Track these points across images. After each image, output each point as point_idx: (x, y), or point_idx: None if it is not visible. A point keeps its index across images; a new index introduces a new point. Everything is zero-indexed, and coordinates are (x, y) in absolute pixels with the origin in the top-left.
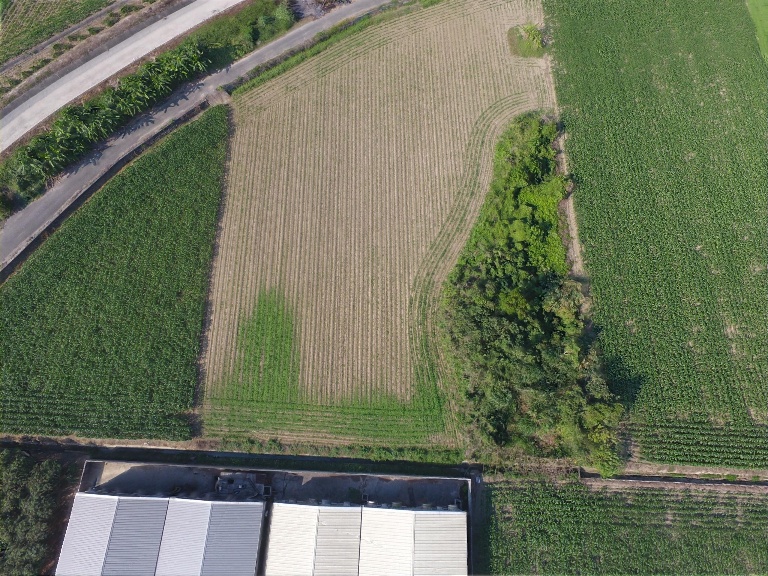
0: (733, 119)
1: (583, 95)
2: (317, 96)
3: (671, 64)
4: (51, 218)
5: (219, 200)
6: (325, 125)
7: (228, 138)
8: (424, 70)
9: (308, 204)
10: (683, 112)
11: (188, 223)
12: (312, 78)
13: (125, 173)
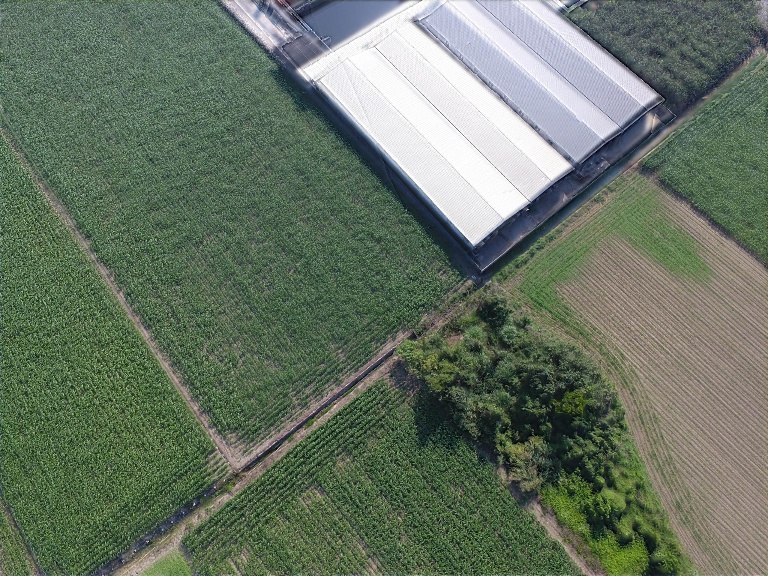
0: None
1: None
2: None
3: None
4: None
5: None
6: None
7: None
8: None
9: None
10: None
11: None
12: None
13: None
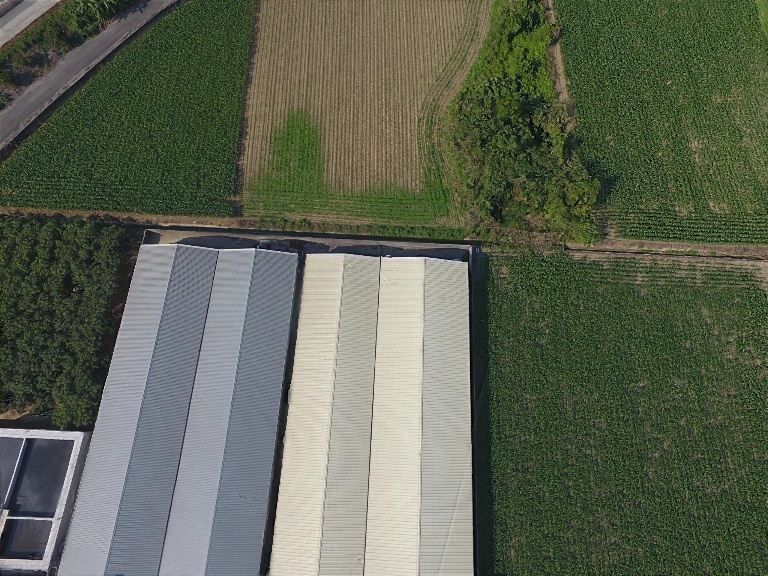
0: None
1: None
2: None
3: None
4: (105, 53)
5: (251, 41)
6: None
7: None
8: None
9: (329, 46)
10: None
11: (225, 57)
12: None
13: (169, 18)
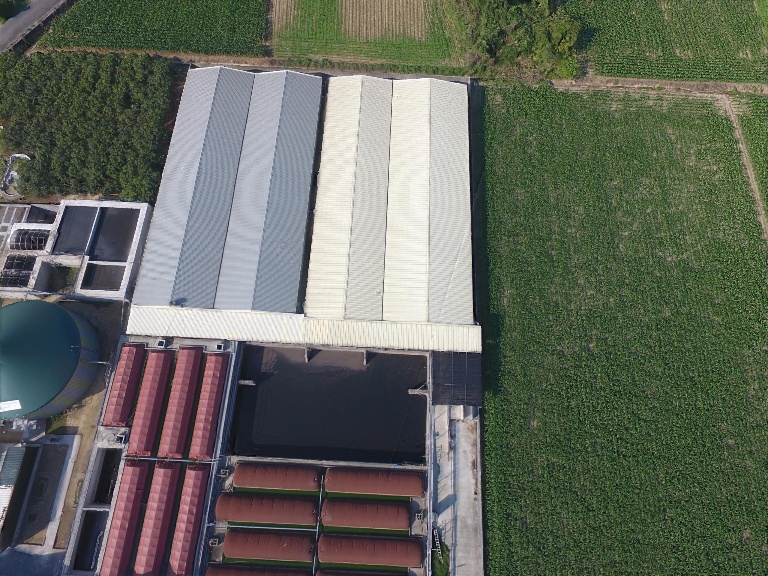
0: None
1: None
2: None
3: None
4: None
5: None
6: None
7: None
8: None
9: None
10: None
11: None
12: None
13: None
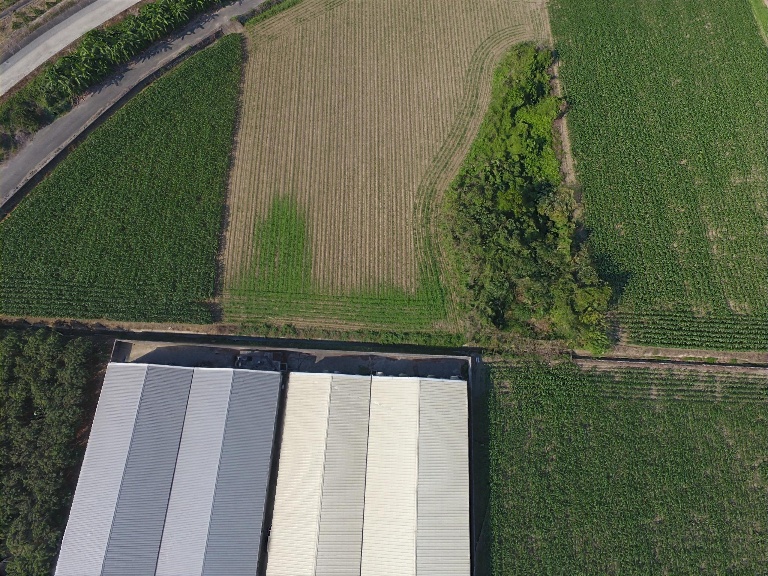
0: (717, 49)
1: (576, 27)
2: (325, 27)
3: (659, 0)
4: (77, 132)
5: (234, 117)
6: (333, 52)
7: (242, 63)
8: (426, 4)
9: (318, 122)
10: (670, 42)
11: (206, 137)
12: (320, 11)
13: (146, 92)
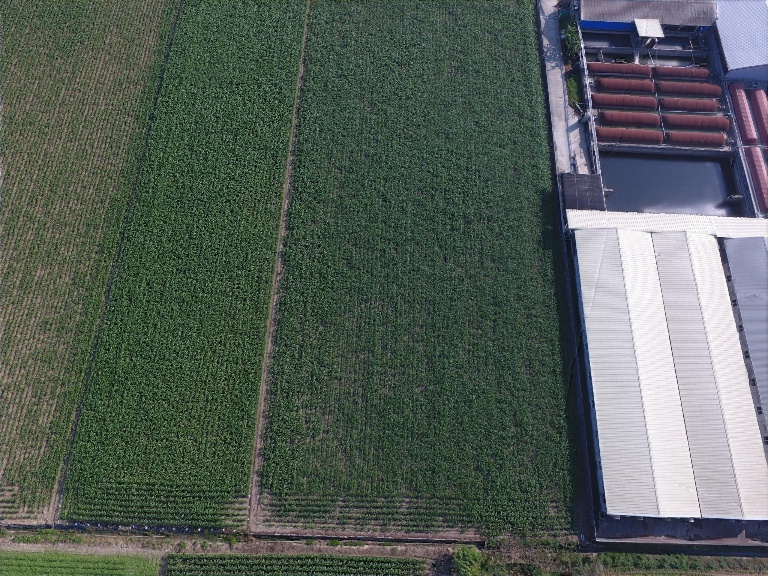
0: None
1: None
2: None
3: None
4: None
5: None
6: None
7: None
8: None
9: None
10: None
11: None
12: None
13: None
